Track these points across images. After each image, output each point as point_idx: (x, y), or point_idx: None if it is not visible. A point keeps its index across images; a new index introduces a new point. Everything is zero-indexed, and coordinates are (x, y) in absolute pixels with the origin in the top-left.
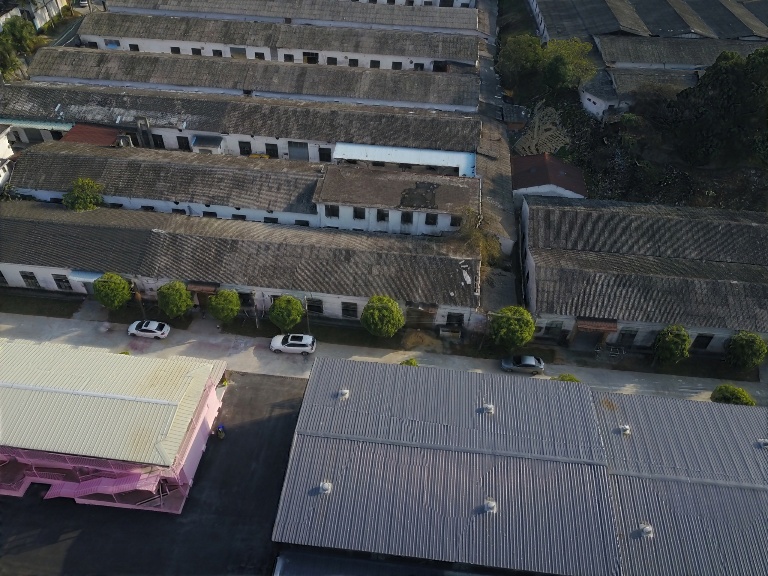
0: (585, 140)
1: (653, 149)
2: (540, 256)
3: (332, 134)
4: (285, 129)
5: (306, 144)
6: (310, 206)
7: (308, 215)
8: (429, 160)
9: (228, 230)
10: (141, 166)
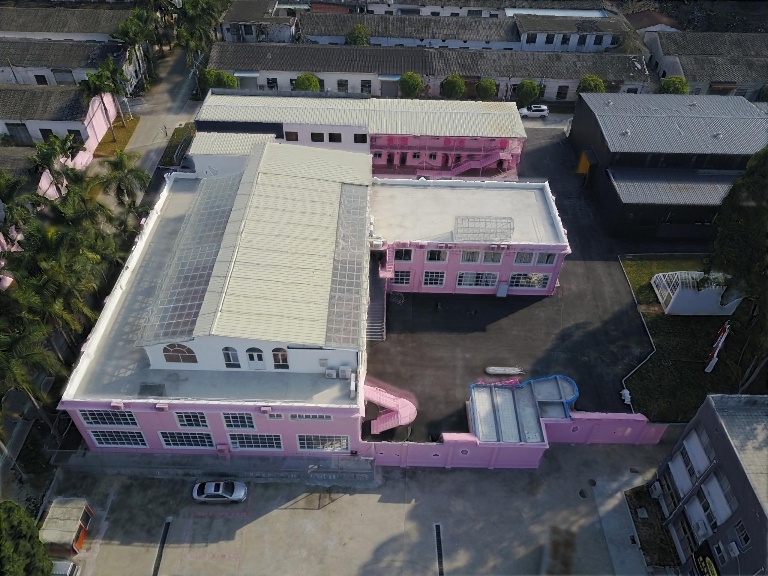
0: (671, 3)
1: (721, 3)
2: (676, 55)
3: (500, 3)
4: (466, 1)
5: (481, 11)
6: (515, 37)
7: (514, 43)
8: (574, 15)
9: (469, 50)
10: (390, 18)
